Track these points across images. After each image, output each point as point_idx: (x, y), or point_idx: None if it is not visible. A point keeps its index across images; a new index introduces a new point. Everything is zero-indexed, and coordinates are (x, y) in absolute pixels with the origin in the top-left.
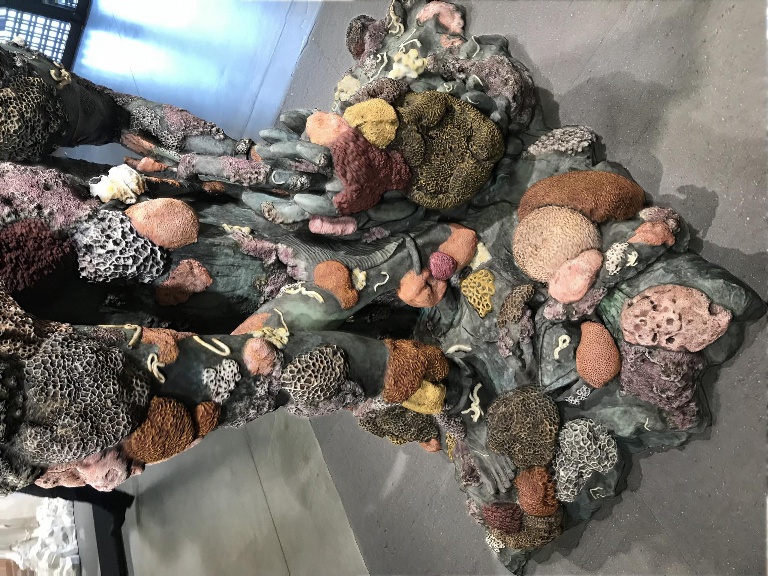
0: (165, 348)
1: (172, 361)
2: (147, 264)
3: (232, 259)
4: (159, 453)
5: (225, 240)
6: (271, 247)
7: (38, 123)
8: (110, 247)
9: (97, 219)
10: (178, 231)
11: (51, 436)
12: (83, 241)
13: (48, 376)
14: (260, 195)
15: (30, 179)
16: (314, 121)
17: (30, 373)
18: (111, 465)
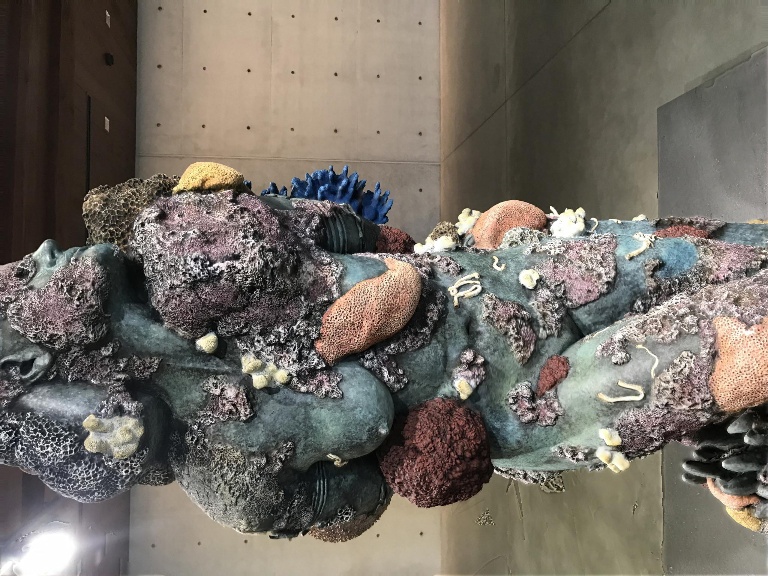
0: None
1: None
2: None
3: None
4: None
5: None
6: None
7: None
8: None
9: None
10: None
11: None
12: None
13: None
14: None
15: None
16: None
17: None
18: None
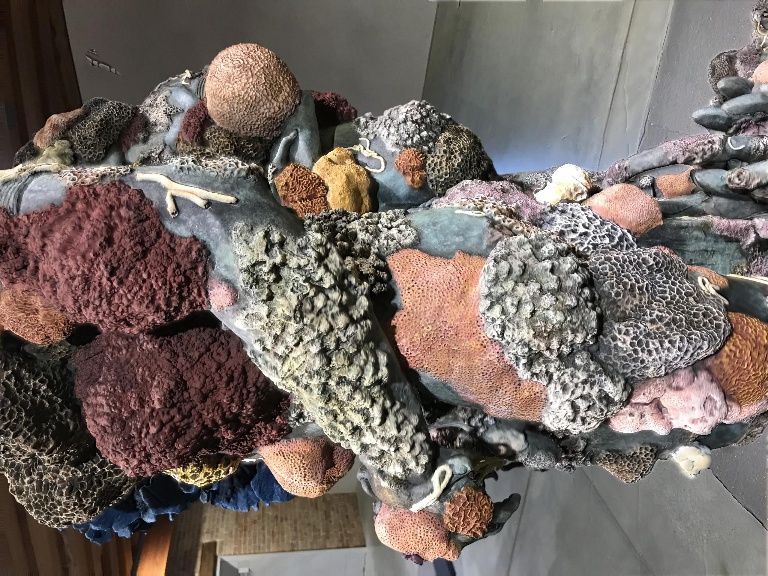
0: (710, 274)
1: (725, 285)
2: (622, 244)
3: (704, 242)
4: (759, 381)
5: (692, 220)
6: (746, 223)
7: (474, 159)
8: (581, 230)
9: (558, 211)
10: (643, 210)
11: (644, 331)
12: (553, 229)
13: (617, 271)
14: (716, 170)
15: (488, 187)
16: (767, 65)
17: (595, 271)
18: (708, 390)
